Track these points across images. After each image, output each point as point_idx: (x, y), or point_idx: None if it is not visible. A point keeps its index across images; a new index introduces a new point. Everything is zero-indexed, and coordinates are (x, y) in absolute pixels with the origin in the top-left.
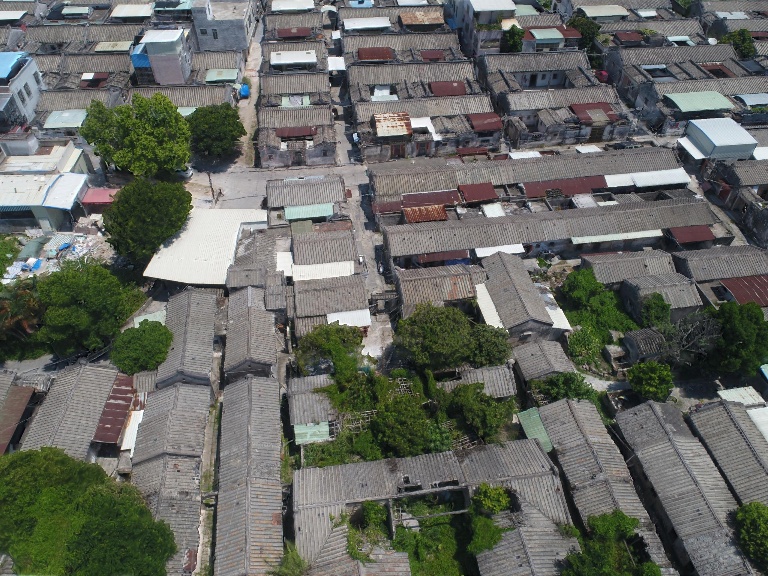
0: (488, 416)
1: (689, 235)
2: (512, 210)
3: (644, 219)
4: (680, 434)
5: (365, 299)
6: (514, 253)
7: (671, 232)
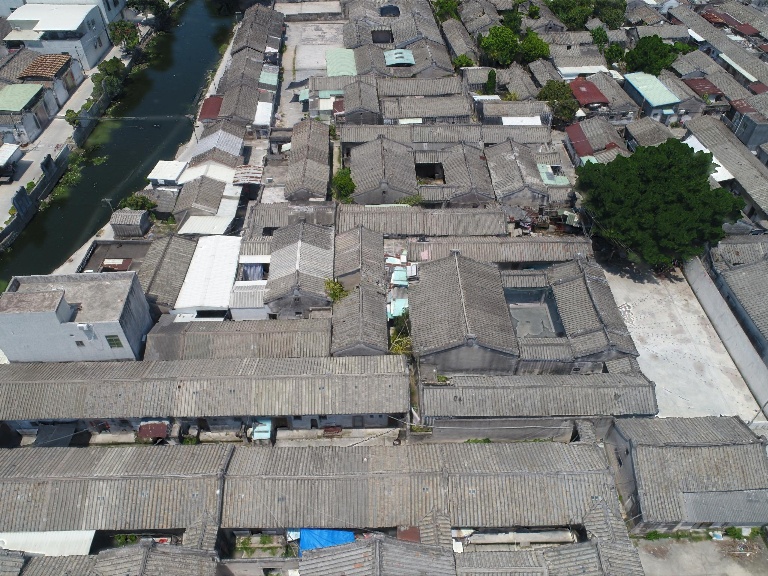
0: (571, 12)
1: (761, 90)
2: (741, 43)
3: (762, 72)
4: (582, 52)
5: (629, 2)
6: (695, 39)
7: (758, 84)
